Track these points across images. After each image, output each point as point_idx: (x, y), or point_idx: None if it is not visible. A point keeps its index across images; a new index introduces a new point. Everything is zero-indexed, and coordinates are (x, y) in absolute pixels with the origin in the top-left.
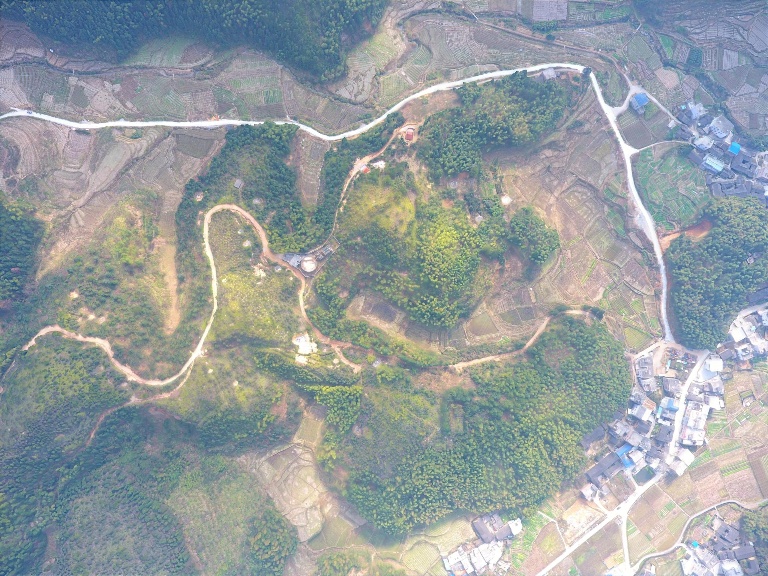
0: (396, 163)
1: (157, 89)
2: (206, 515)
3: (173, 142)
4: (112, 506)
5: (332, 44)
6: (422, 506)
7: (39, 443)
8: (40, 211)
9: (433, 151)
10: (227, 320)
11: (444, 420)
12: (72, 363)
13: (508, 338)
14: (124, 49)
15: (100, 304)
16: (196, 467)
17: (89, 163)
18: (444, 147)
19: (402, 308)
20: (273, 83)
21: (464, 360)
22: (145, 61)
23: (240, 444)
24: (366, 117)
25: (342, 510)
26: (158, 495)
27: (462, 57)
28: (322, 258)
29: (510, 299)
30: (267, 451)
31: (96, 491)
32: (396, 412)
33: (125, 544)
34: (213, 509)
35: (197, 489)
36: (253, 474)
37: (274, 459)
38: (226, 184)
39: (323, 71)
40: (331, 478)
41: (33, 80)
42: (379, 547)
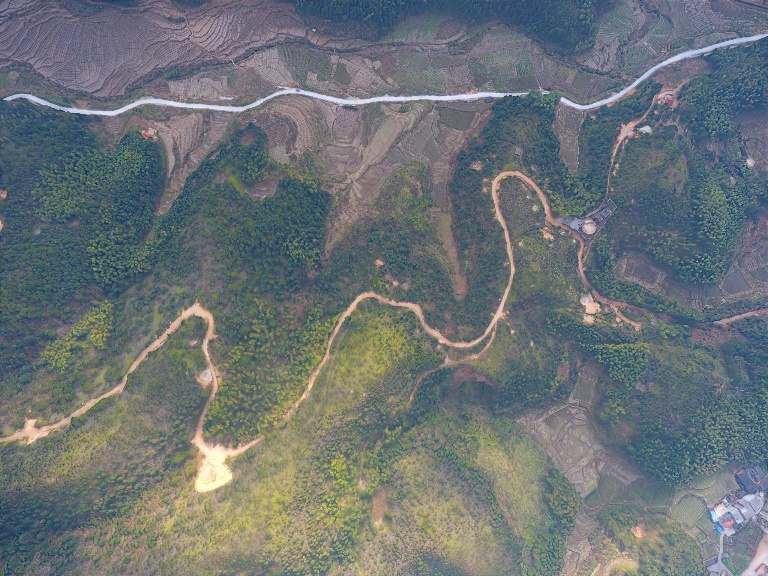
0: (665, 127)
1: (415, 65)
2: (508, 473)
3: (437, 115)
4: (437, 465)
5: (588, 16)
6: (705, 457)
7: (376, 404)
8: (323, 185)
9: (697, 115)
10: (529, 281)
11: (735, 371)
12: (396, 326)
13: (761, 294)
14: (386, 26)
15: (400, 271)
16: (487, 428)
17: (360, 138)
18: (707, 110)
19: (664, 269)
20: (524, 56)
21: (727, 316)
22: (402, 38)
23: (525, 405)
24: (616, 86)
25: (615, 467)
26: (468, 455)
27: (701, 26)
28: (601, 220)
29: (758, 257)
30: (544, 412)
31: (419, 451)
32: (684, 366)
33: (455, 501)
34: (512, 468)
35: (496, 449)
36: (533, 435)
37: (550, 420)
38: (507, 152)
39: (575, 42)
40: (609, 435)
41: (297, 59)
42: (649, 502)
